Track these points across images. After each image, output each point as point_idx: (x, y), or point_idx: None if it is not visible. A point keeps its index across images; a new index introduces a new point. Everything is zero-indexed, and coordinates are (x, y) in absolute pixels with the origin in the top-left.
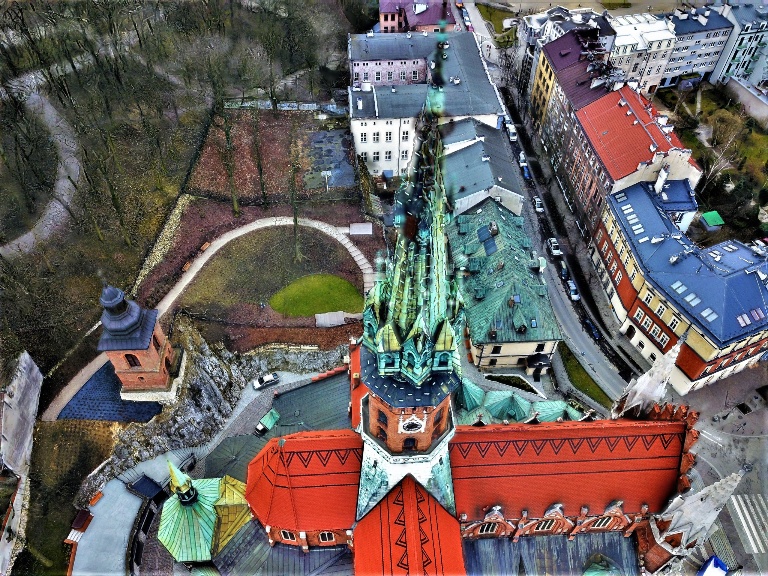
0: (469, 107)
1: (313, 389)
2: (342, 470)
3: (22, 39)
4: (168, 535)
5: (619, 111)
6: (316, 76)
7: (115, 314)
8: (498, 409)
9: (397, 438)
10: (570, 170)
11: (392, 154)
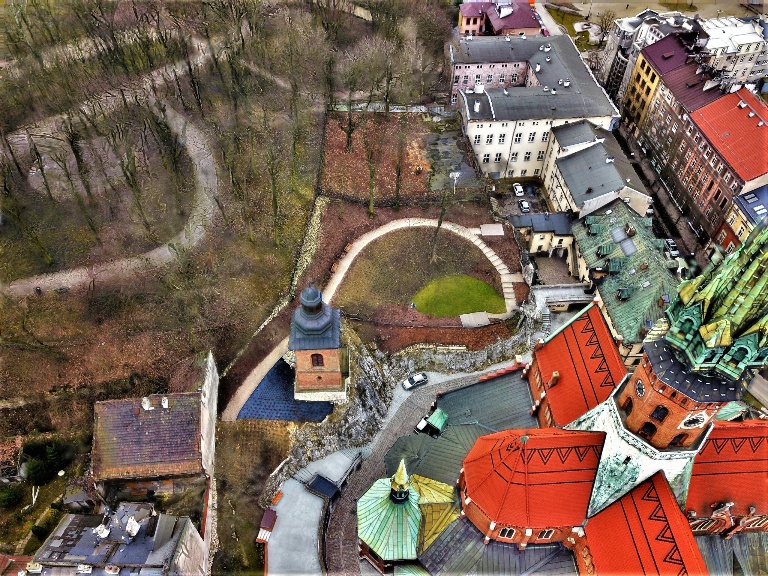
0: (583, 109)
1: (482, 388)
2: (579, 467)
3: (134, 42)
4: (371, 534)
5: (740, 113)
6: (412, 79)
7: (313, 313)
8: None
9: (671, 434)
10: (680, 172)
11: (502, 156)
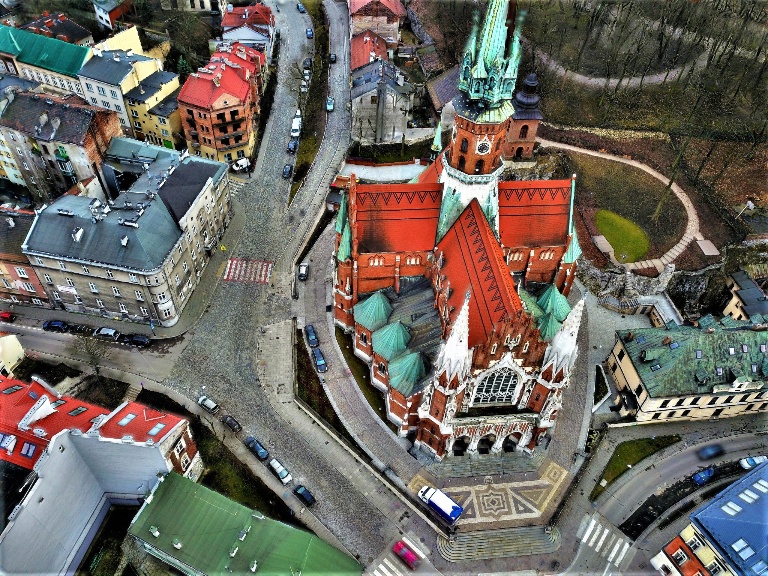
0: None
1: None
2: None
3: None
4: None
5: None
6: None
7: (524, 91)
8: None
9: None
10: None
11: None
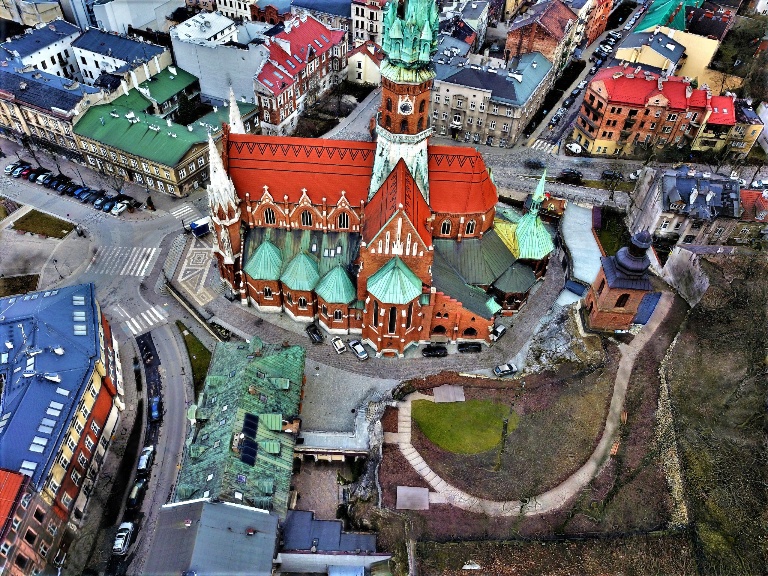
0: None
1: None
2: None
3: None
4: None
5: None
6: None
7: None
8: None
9: None
10: None
11: None
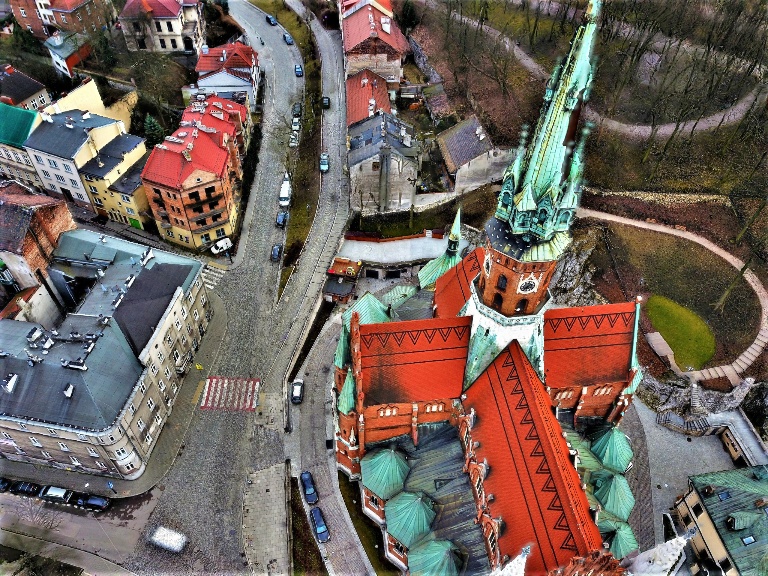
0: None
1: None
2: None
3: None
4: None
5: None
6: None
7: None
8: (600, 472)
9: None
10: None
11: None
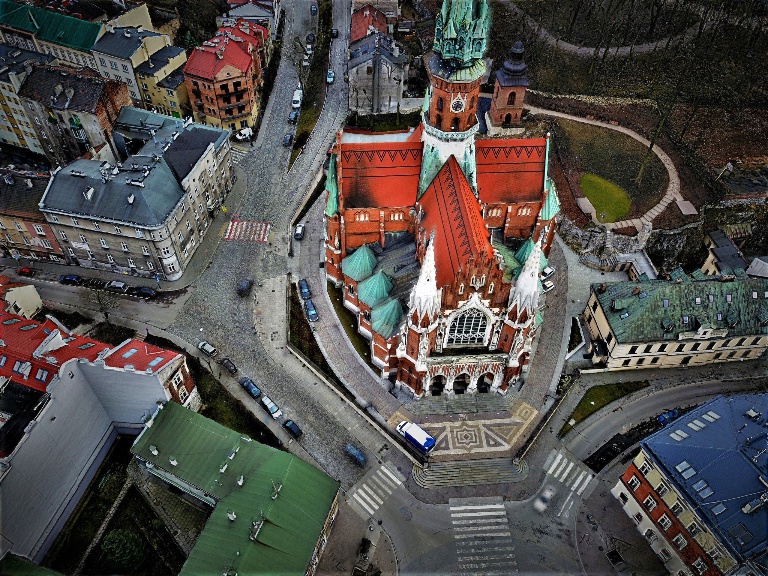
0: None
1: None
2: None
3: None
4: None
5: None
6: None
7: (510, 58)
8: None
9: None
10: None
11: None
